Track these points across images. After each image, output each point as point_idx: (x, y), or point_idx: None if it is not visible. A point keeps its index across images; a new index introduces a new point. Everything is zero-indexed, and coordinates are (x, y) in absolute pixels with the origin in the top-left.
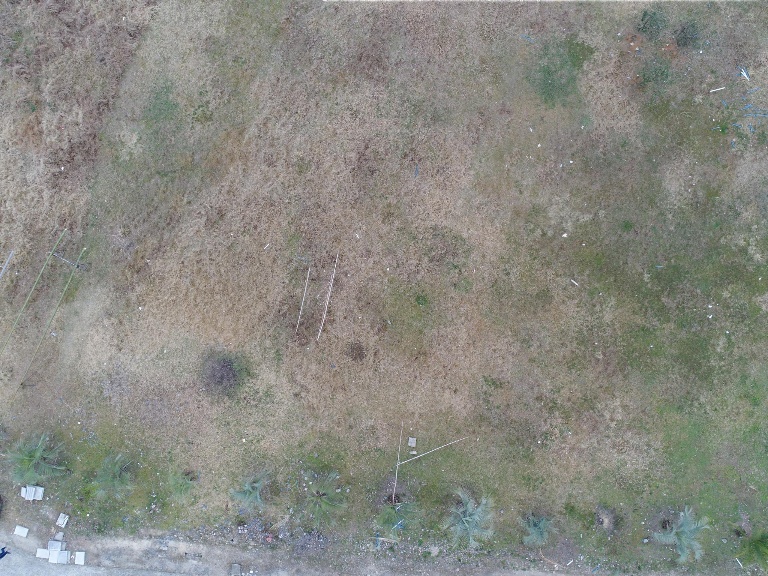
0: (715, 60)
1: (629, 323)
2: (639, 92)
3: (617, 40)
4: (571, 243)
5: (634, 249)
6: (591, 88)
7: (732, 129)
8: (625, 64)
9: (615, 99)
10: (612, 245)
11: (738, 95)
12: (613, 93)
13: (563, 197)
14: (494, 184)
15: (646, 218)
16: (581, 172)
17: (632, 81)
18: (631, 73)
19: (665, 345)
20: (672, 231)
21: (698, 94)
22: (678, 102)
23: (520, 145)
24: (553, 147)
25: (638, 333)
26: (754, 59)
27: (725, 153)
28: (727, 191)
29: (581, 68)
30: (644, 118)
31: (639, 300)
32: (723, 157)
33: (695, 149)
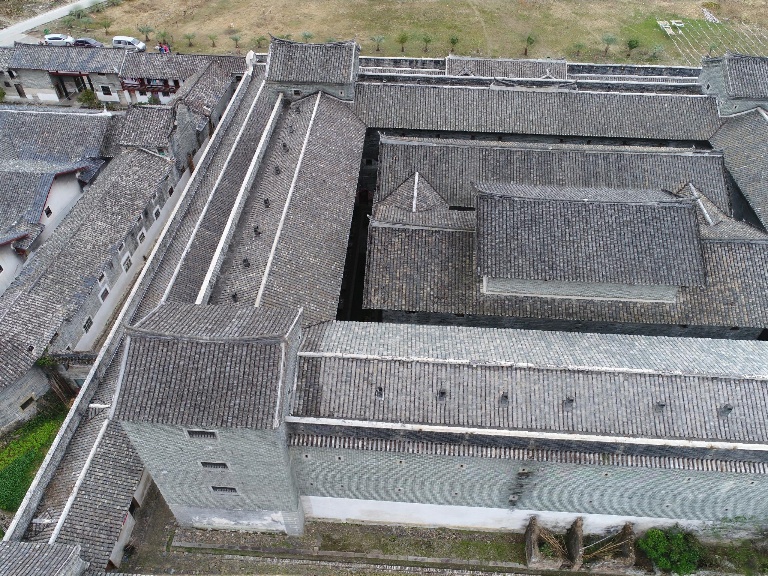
0: None
1: None
2: None
3: None
4: None
5: None
6: None
7: None
8: None
9: None
10: None
11: None
12: None
13: None
14: (324, 8)
15: None
16: None
17: None
18: None
19: None
20: None
21: None
22: None
23: (332, 4)
24: (342, 4)
25: None
26: None
27: (393, 4)
28: None
29: None
30: (369, 1)
31: None
32: None
33: (384, 4)
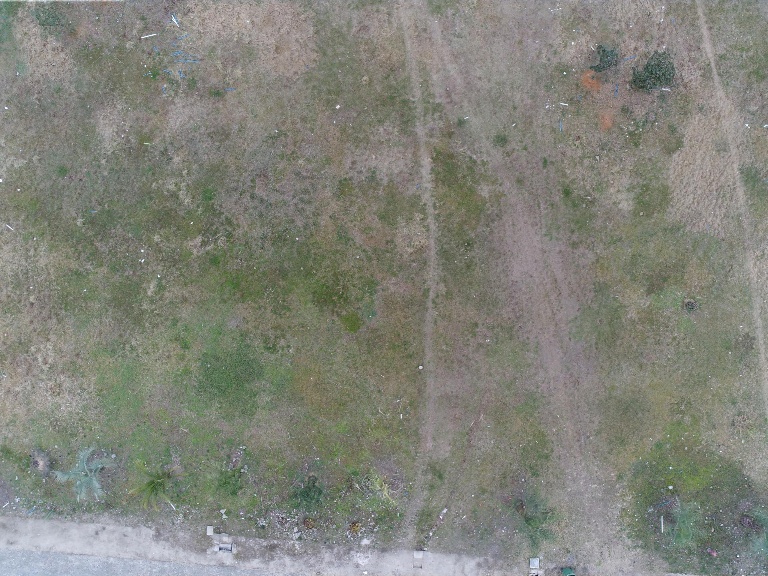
0: (146, 7)
1: (62, 267)
2: (71, 39)
3: None
4: (6, 188)
5: (69, 194)
6: (26, 35)
7: (163, 75)
8: (58, 11)
9: (49, 46)
10: (47, 190)
11: (169, 41)
12: (47, 40)
13: None
14: None
15: (81, 164)
16: (16, 118)
17: (64, 28)
18: (64, 20)
19: (98, 289)
20: (106, 176)
21: (129, 40)
22: (111, 49)
23: None
24: None
25: (72, 277)
26: (183, 6)
27: (156, 99)
28: (159, 136)
29: (16, 15)
30: (78, 64)
31: (73, 245)
32: (154, 103)
33: (127, 95)
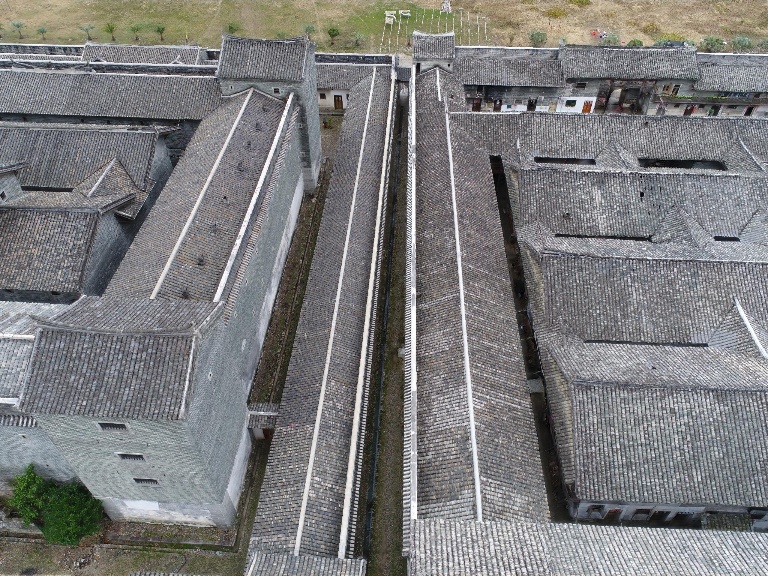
0: None
1: None
2: None
3: None
4: (89, 5)
5: (108, 6)
6: None
7: None
8: None
9: None
10: None
11: None
12: None
13: (92, 0)
14: None
15: None
16: None
17: None
18: None
19: None
20: (122, 4)
21: None
22: None
23: None
24: None
25: (101, 15)
26: None
27: None
28: None
29: None
30: None
31: None
32: None
33: None
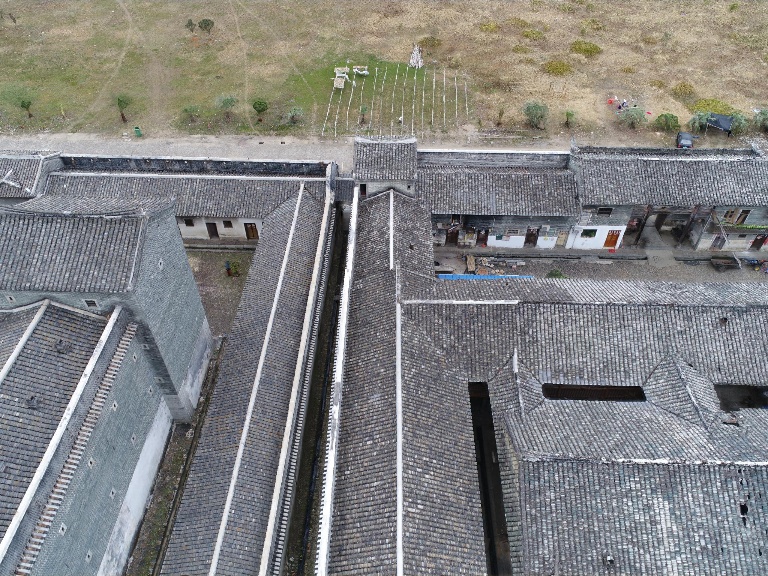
0: None
1: None
2: None
3: (1, 28)
4: None
5: None
6: None
7: (31, 41)
8: None
9: None
10: None
11: None
12: None
13: None
14: None
15: None
16: None
17: (0, 34)
18: None
19: None
20: None
21: None
22: None
23: None
24: None
25: None
26: (48, 30)
27: None
28: None
29: None
30: None
31: None
32: None
33: None
